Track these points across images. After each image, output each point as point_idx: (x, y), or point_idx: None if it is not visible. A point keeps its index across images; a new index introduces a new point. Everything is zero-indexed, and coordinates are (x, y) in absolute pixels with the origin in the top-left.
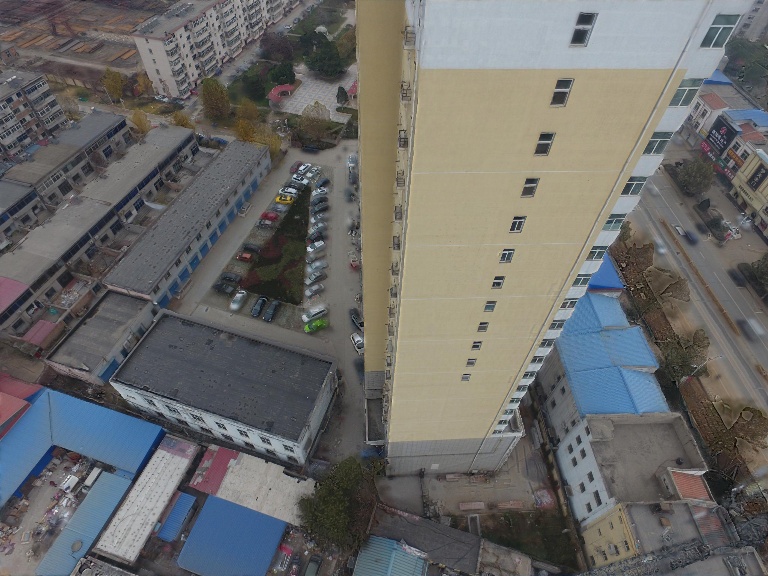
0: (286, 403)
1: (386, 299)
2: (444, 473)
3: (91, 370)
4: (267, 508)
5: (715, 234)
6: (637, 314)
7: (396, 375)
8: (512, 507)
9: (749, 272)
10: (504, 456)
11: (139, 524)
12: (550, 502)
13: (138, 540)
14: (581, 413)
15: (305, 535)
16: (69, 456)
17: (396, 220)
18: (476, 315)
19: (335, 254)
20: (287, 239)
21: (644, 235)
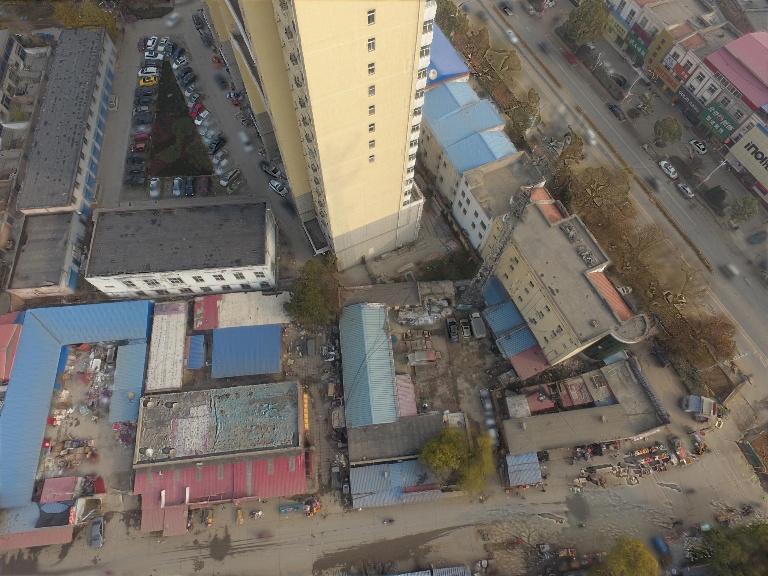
0: (243, 243)
1: (294, 124)
2: (379, 255)
3: (57, 283)
4: (261, 321)
5: (535, 7)
6: (488, 94)
7: (323, 172)
8: (432, 258)
9: (564, 33)
10: (417, 224)
11: (170, 365)
12: (456, 246)
13: (176, 374)
14: (460, 174)
15: (296, 328)
16: (81, 349)
17: (289, 39)
18: (364, 101)
19: (223, 120)
20: (171, 119)
21: (481, 24)
